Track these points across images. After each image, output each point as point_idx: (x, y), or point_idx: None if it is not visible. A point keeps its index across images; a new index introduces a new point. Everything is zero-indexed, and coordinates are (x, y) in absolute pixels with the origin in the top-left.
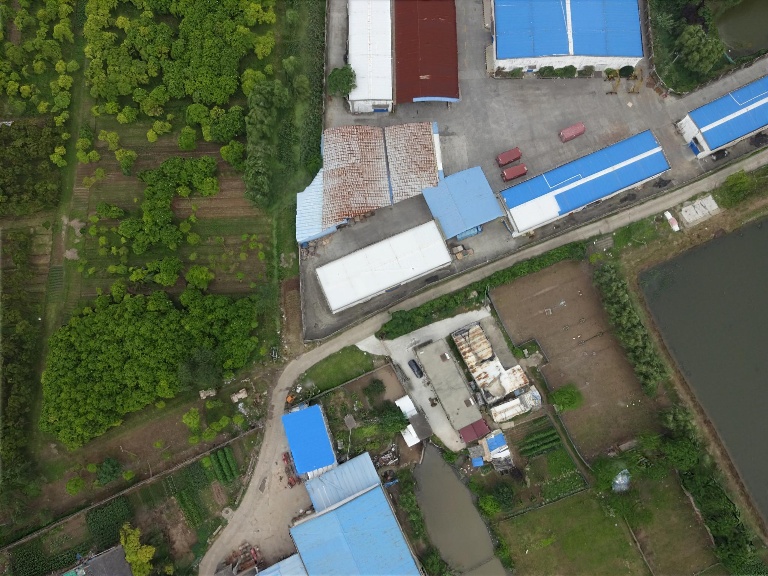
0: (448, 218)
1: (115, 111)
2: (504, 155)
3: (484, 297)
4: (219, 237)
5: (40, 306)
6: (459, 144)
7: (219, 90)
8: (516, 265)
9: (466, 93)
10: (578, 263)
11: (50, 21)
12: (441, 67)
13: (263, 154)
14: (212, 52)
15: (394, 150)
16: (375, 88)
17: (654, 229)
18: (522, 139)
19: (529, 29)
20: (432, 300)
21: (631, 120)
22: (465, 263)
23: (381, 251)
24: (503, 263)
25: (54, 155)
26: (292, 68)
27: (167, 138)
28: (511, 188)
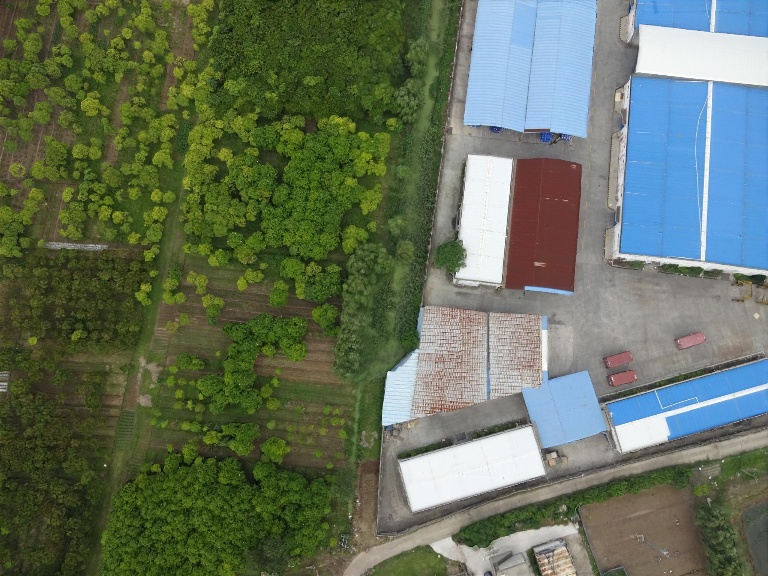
0: (547, 425)
1: (207, 253)
2: (614, 358)
3: (574, 514)
4: (300, 406)
5: (108, 457)
6: (565, 335)
7: (319, 248)
8: (613, 485)
9: (579, 278)
10: (679, 489)
11: (151, 143)
12: (559, 255)
13: (358, 328)
14: (317, 206)
15: (497, 340)
16: (485, 268)
17: (767, 462)
18: (634, 339)
19: (659, 224)
20: (518, 511)
21: (756, 334)
22: (557, 470)
23: (471, 453)
24: (598, 477)
25: (140, 293)
26: (398, 231)
27: (257, 286)
28: (619, 402)
